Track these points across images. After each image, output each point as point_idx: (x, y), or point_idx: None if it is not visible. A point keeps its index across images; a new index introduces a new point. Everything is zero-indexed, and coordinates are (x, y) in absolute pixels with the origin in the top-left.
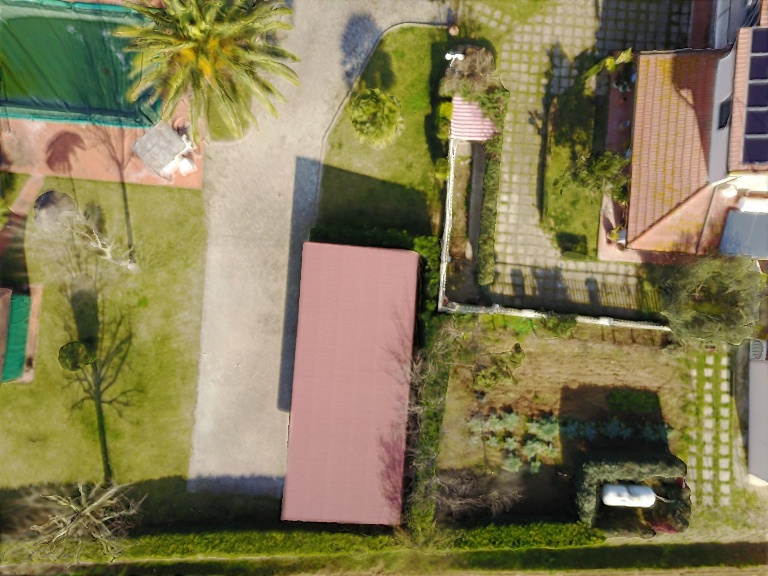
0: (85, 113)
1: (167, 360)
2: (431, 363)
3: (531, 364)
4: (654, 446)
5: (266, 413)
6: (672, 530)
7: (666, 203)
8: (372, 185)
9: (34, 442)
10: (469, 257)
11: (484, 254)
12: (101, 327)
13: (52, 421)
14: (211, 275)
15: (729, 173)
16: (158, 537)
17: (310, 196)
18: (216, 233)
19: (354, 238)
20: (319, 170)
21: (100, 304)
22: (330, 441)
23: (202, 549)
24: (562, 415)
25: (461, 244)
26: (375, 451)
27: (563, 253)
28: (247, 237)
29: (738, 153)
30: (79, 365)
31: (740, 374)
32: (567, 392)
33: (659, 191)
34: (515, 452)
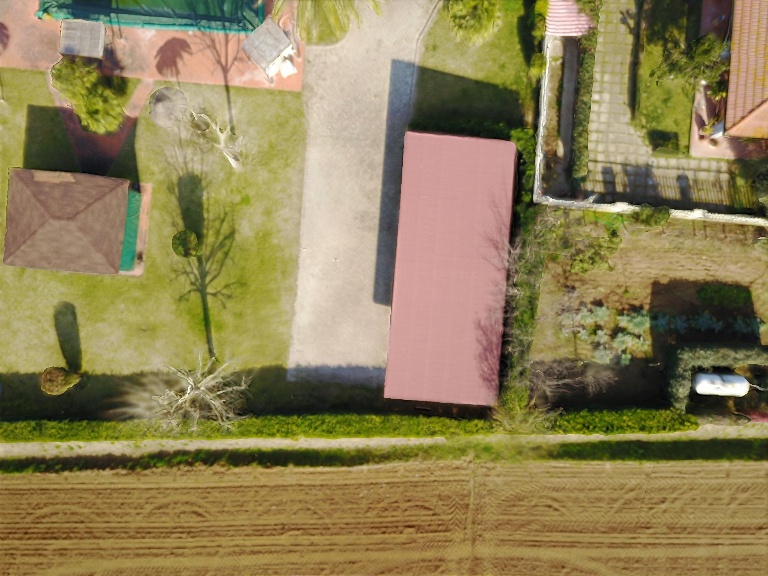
0: (191, 19)
1: (268, 254)
2: (529, 249)
3: (622, 260)
4: (746, 340)
5: (363, 306)
6: (767, 417)
7: (766, 88)
8: (465, 85)
9: (145, 331)
10: (560, 155)
11: (579, 147)
12: (206, 223)
13: (161, 311)
14: (310, 173)
15: None
16: (264, 417)
17: (404, 97)
18: (314, 133)
19: (451, 131)
20: (413, 71)
21: (205, 201)
22: (430, 324)
23: (306, 429)
24: (653, 309)
25: (552, 143)
26: (474, 334)
27: (655, 150)
28: (344, 137)
29: None
30: (191, 252)
31: None
32: (658, 287)
33: (759, 77)
34: (606, 345)
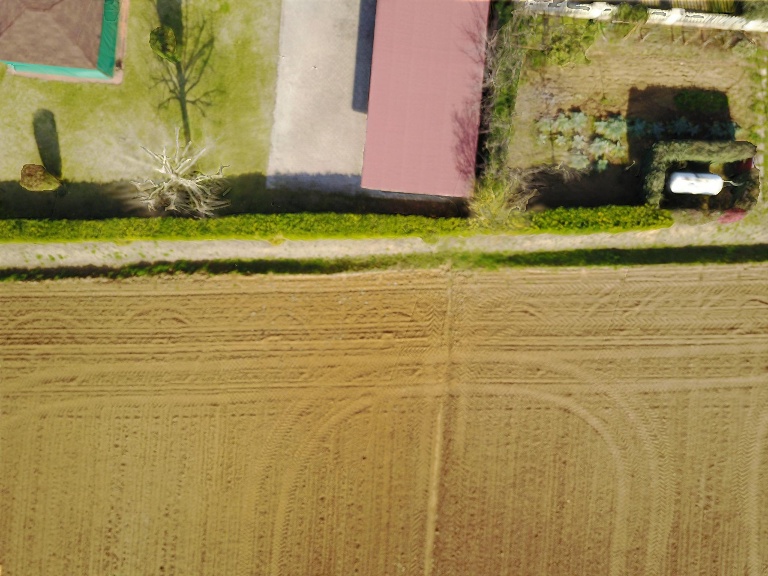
0: None
1: (247, 62)
2: (506, 39)
3: (600, 67)
4: None
5: (341, 114)
6: (739, 212)
7: None
8: None
9: (124, 139)
10: None
11: None
12: (185, 31)
13: (140, 120)
14: None
15: None
16: (243, 216)
17: None
18: None
19: None
20: None
21: (184, 9)
22: (407, 115)
23: (284, 227)
24: (630, 116)
25: None
26: (450, 126)
27: None
28: None
29: None
30: (169, 47)
31: None
32: (635, 93)
33: None
34: (583, 152)
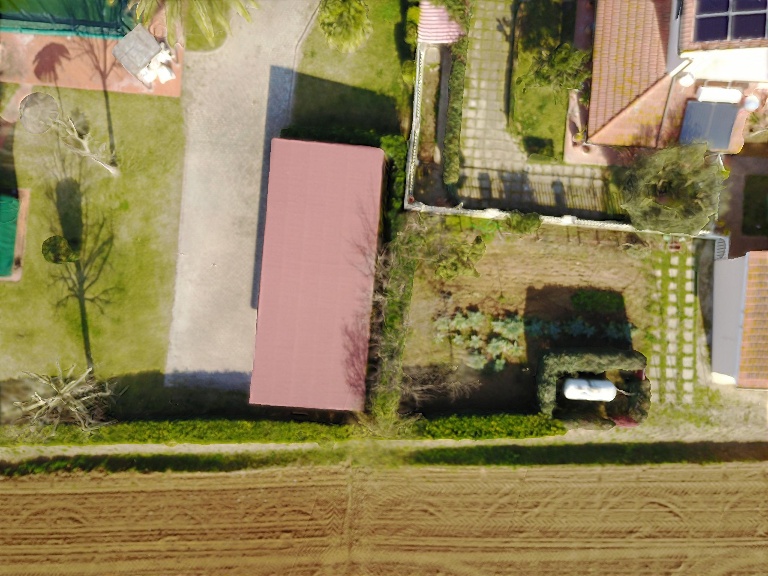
0: (69, 24)
1: (147, 260)
2: (394, 255)
3: (497, 265)
4: (618, 345)
5: (240, 311)
6: (632, 422)
7: (625, 96)
8: (343, 91)
9: (22, 336)
10: (437, 161)
11: (449, 153)
12: (85, 228)
13: (39, 317)
14: (188, 179)
15: (680, 54)
16: (136, 423)
17: (283, 103)
18: (193, 139)
19: (322, 138)
20: (292, 78)
21: (84, 206)
22: (297, 329)
23: (177, 434)
24: (527, 315)
25: (430, 149)
26: (340, 340)
27: (529, 156)
28: (223, 143)
29: (689, 34)
30: (61, 257)
31: (705, 275)
32: (532, 292)
33: (619, 85)
34: (481, 350)
